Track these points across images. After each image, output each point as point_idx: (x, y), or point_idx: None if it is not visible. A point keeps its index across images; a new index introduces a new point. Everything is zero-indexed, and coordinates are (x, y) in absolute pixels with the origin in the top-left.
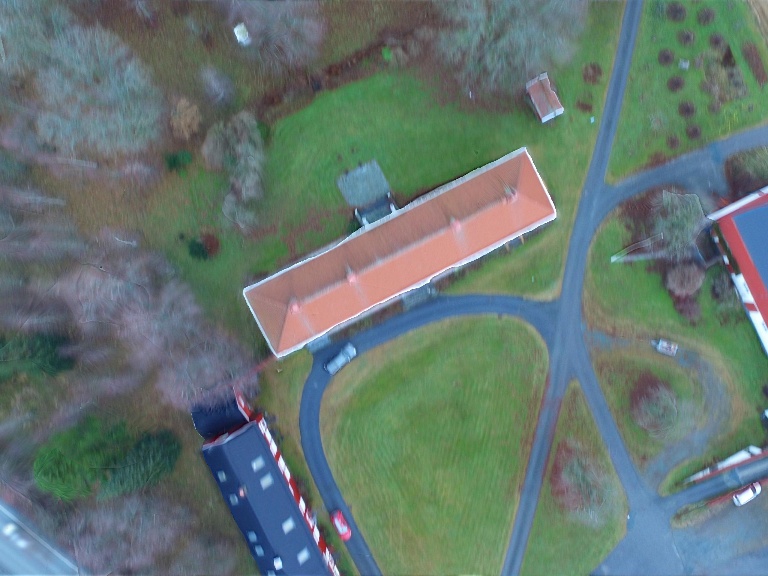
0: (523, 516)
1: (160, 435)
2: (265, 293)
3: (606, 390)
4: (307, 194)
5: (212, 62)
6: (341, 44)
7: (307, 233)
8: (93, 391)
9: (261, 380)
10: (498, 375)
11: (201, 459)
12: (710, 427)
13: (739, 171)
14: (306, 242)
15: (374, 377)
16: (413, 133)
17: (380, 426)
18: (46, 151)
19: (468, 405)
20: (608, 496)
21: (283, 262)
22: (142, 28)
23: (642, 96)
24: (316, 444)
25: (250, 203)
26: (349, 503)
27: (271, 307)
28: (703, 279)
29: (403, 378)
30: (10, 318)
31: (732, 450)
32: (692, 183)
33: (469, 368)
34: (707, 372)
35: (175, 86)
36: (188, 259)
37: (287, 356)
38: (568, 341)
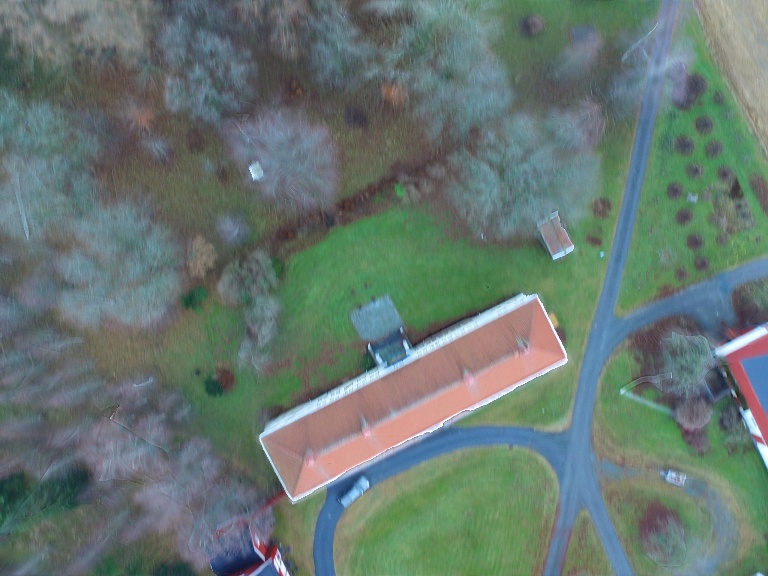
0: None
1: (176, 568)
2: (281, 442)
3: (615, 519)
4: (321, 329)
5: (227, 196)
6: (354, 178)
7: (321, 367)
8: (111, 526)
9: (276, 512)
10: (509, 505)
11: None
12: (718, 555)
13: (747, 302)
14: (320, 376)
15: (387, 508)
16: (425, 268)
17: (393, 556)
18: (64, 288)
19: (479, 535)
20: None
21: (297, 397)
22: (158, 165)
23: (651, 229)
24: (330, 574)
25: (266, 346)
26: None
27: (287, 456)
28: (711, 415)
29: (415, 509)
30: (29, 452)
31: None
32: (700, 313)
33: (480, 498)
34: (715, 501)
35: (191, 220)
36: (204, 395)
37: None
38: (578, 471)
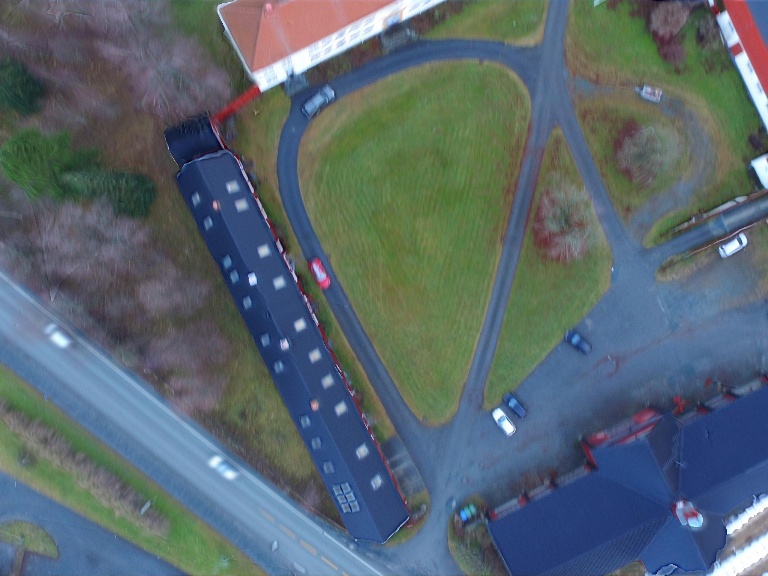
0: (505, 267)
1: (135, 176)
2: (239, 4)
3: (589, 139)
4: None
5: None
6: None
7: None
8: (66, 128)
9: (238, 124)
10: (479, 122)
11: (177, 204)
12: (695, 178)
13: None
14: None
15: (353, 122)
16: None
17: (359, 173)
18: None
19: (449, 152)
20: (592, 247)
21: None
22: None
23: None
24: (294, 190)
25: None
26: (328, 252)
27: (245, 16)
28: (687, 16)
29: (382, 124)
30: None
31: (718, 202)
32: None
33: (450, 114)
34: (692, 121)
35: None
36: None
37: (264, 93)
38: (550, 88)
